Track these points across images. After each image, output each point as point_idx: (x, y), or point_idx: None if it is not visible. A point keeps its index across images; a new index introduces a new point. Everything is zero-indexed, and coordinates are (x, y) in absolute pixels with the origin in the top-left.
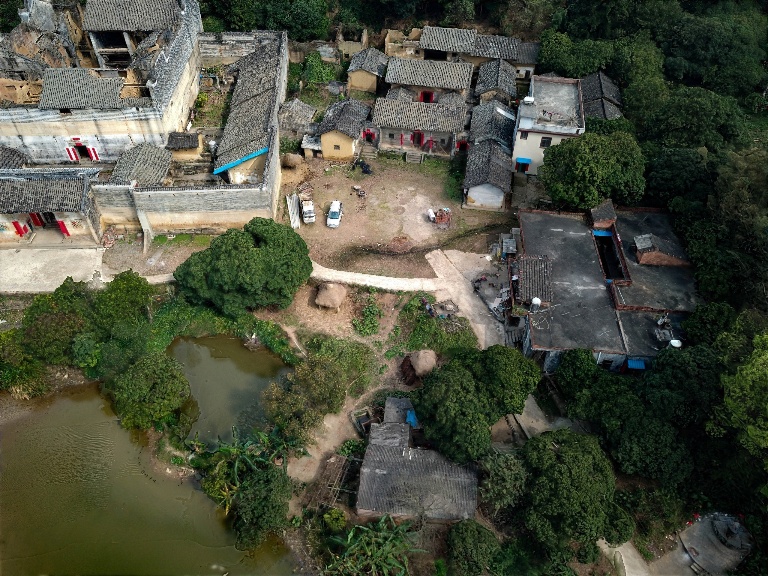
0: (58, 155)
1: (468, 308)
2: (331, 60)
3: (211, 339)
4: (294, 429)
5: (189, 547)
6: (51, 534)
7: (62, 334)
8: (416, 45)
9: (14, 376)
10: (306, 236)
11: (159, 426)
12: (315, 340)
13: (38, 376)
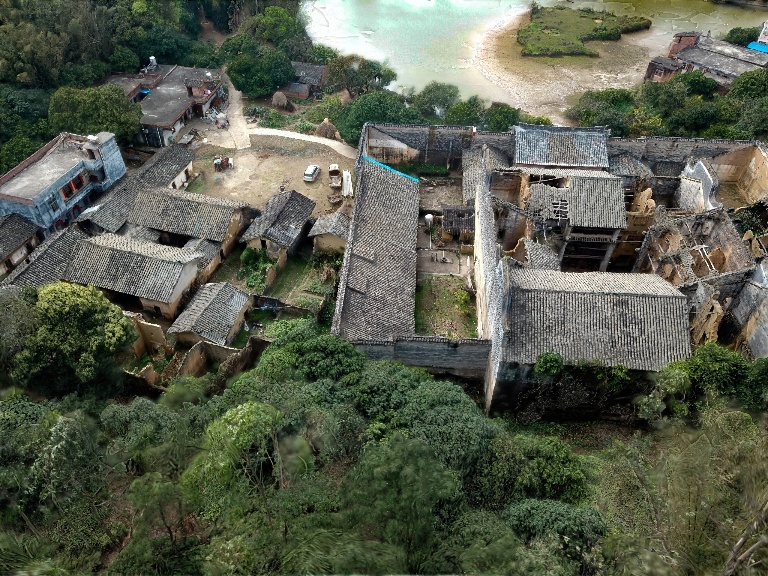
0: None
1: (239, 120)
2: None
3: None
4: None
5: None
6: (463, 87)
7: None
8: None
9: None
10: (339, 165)
11: None
12: None
13: None
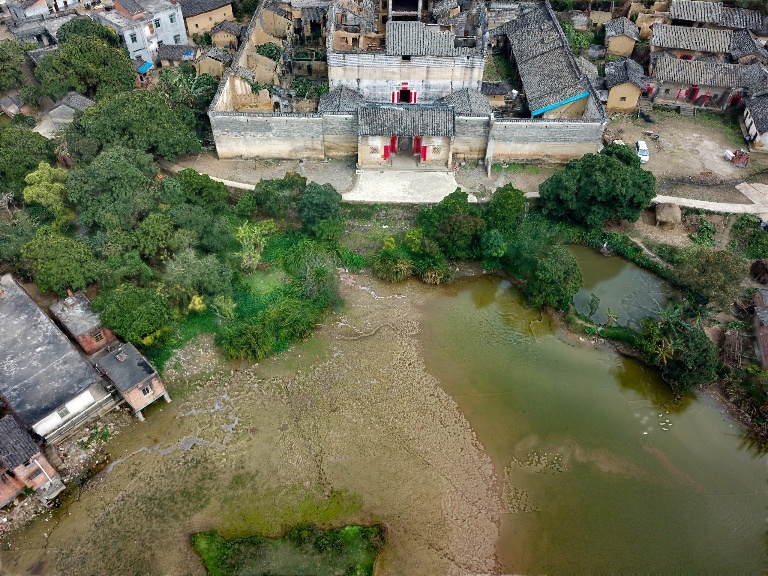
0: (383, 98)
1: None
2: (582, 28)
3: (566, 247)
4: (724, 298)
5: (620, 395)
6: (511, 378)
7: (468, 231)
8: (666, 15)
9: (429, 264)
10: None
11: (563, 306)
12: (664, 249)
13: (446, 265)
